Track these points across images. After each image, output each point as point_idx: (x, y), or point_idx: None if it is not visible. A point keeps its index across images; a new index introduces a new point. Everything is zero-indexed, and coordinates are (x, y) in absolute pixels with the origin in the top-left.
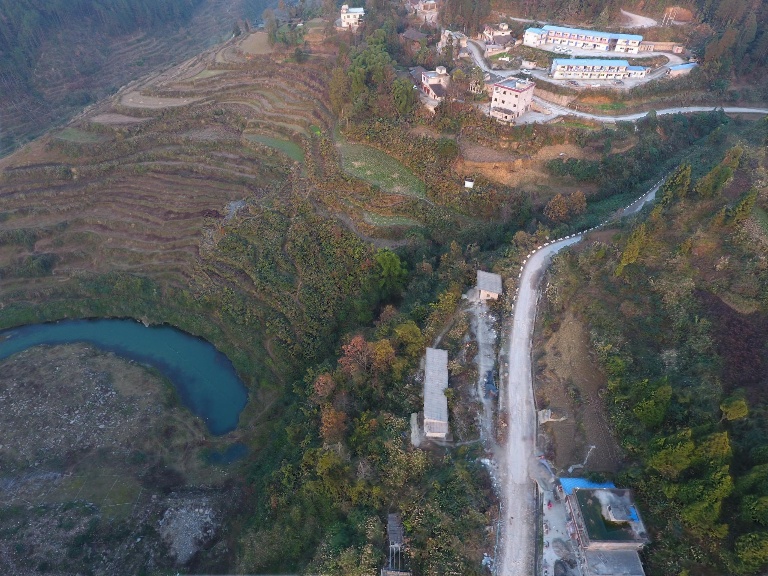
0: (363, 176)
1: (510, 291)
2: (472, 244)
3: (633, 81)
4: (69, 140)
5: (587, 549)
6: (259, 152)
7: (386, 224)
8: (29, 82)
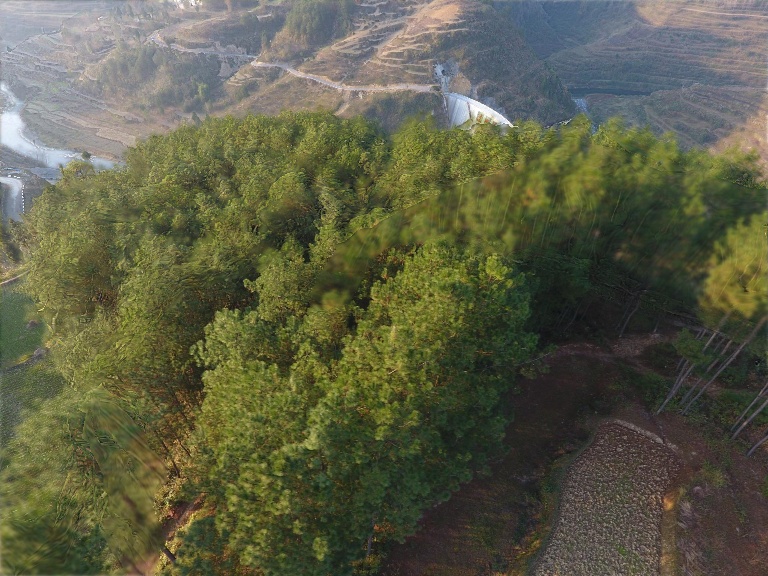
0: None
1: None
2: None
3: None
4: None
5: None
6: None
7: None
8: None
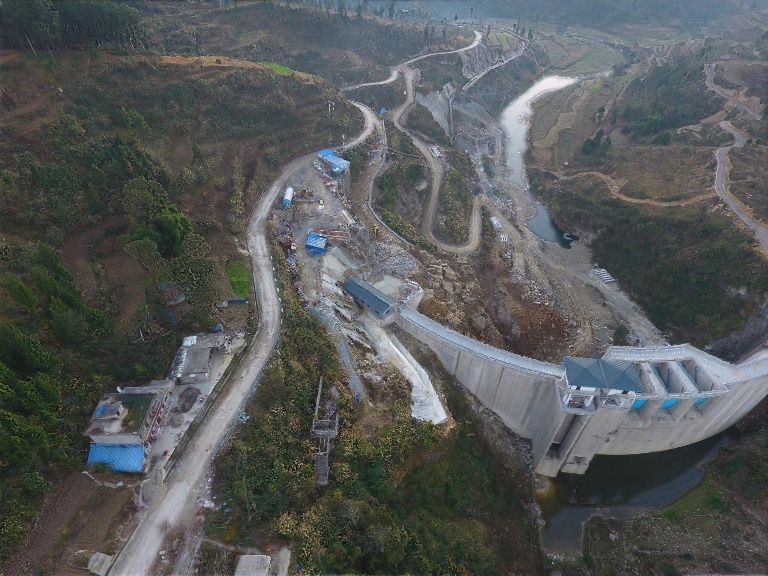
0: None
1: None
2: None
3: None
4: None
5: None
6: None
7: None
8: None
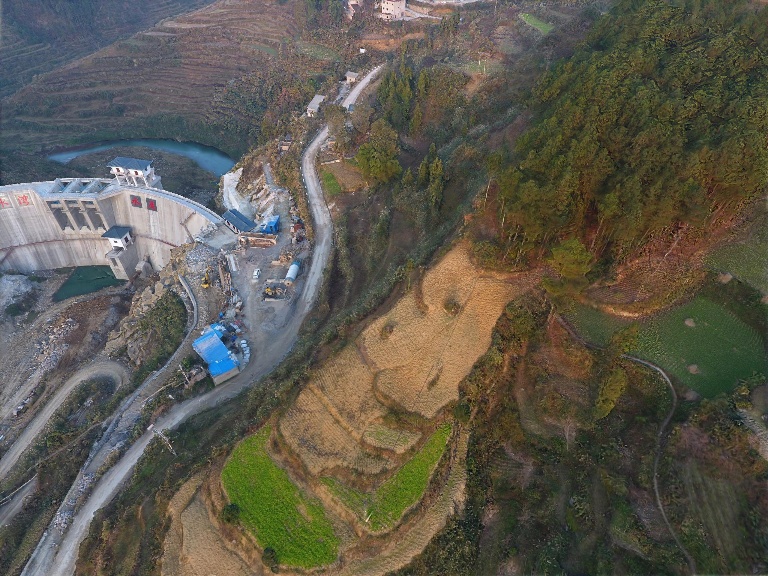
0: (308, 54)
1: (360, 76)
2: (352, 67)
3: (468, 1)
4: (132, 44)
5: None
6: (250, 53)
7: (317, 75)
8: (92, 26)
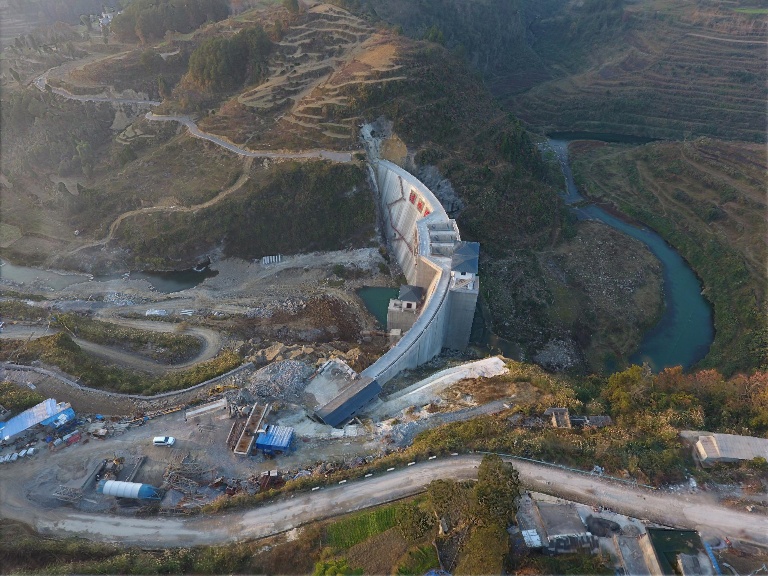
0: None
1: None
2: None
3: None
4: None
5: (639, 541)
6: None
7: None
8: None
